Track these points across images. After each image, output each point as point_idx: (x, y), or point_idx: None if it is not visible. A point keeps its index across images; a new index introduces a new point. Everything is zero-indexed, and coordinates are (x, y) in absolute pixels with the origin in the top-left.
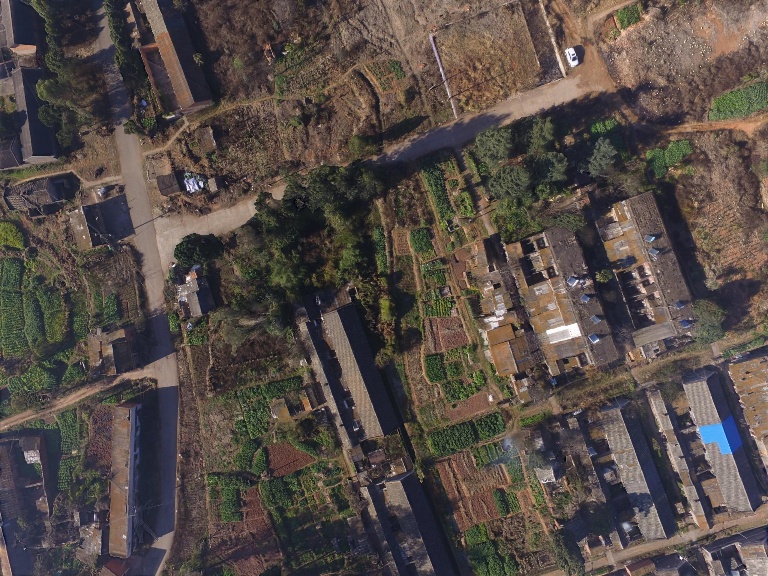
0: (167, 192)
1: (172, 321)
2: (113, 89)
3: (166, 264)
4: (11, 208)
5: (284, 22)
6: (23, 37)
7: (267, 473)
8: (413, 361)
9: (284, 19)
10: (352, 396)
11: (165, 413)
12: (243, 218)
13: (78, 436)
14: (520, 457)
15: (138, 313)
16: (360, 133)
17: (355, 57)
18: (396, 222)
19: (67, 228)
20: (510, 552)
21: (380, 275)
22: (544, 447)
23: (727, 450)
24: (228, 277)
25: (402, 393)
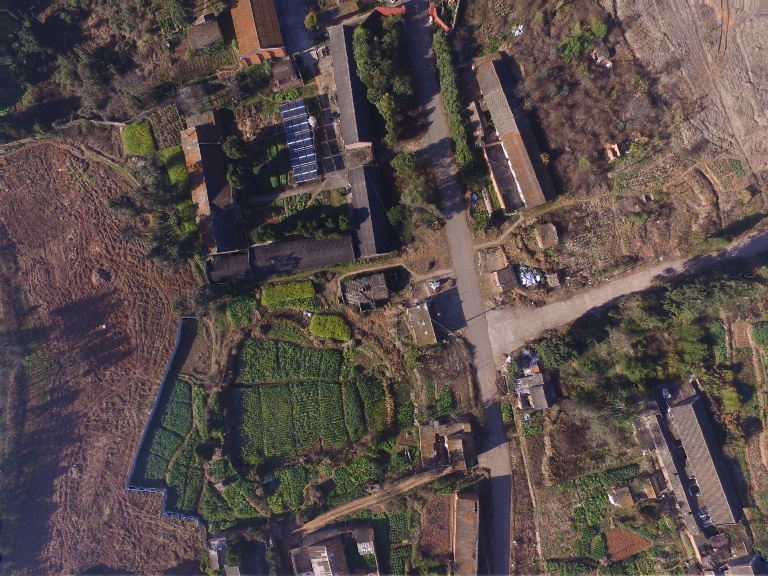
0: (507, 287)
1: (506, 412)
2: (443, 183)
3: (498, 355)
4: (346, 303)
5: (631, 123)
6: (364, 135)
7: (607, 558)
8: (753, 448)
9: (629, 119)
10: (699, 485)
11: (498, 501)
12: (579, 311)
13: (408, 525)
14: None
15: (471, 404)
16: (705, 231)
17: (696, 156)
18: (739, 316)
19: (399, 321)
20: None
21: (720, 366)
22: None
23: None
24: (566, 369)
25: (742, 479)
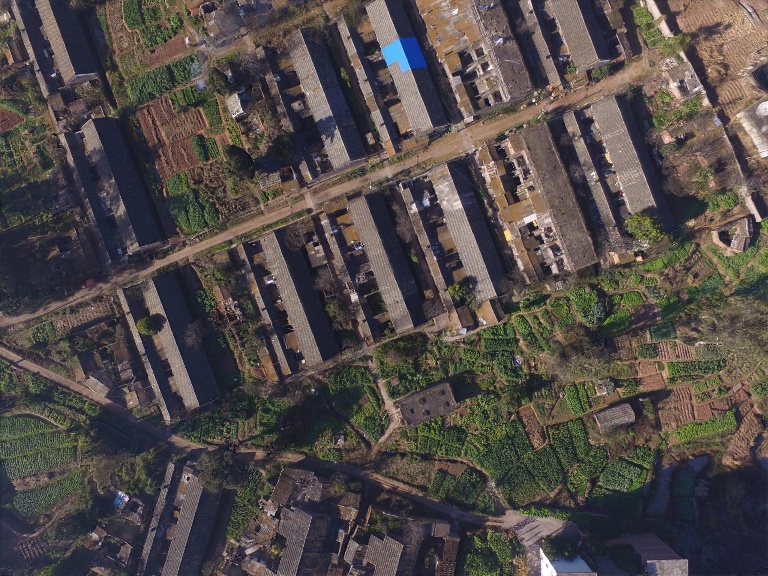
0: None
1: None
2: None
3: None
4: None
5: None
6: None
7: None
8: (114, 10)
9: None
10: None
11: None
12: None
13: None
14: (217, 100)
15: None
16: None
17: None
18: None
19: None
20: (212, 201)
21: None
22: (232, 78)
23: (406, 66)
24: None
25: (103, 43)
